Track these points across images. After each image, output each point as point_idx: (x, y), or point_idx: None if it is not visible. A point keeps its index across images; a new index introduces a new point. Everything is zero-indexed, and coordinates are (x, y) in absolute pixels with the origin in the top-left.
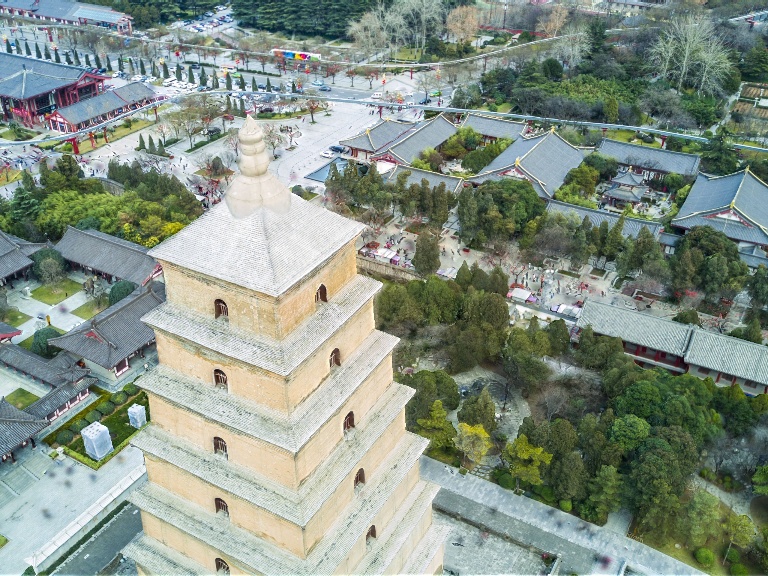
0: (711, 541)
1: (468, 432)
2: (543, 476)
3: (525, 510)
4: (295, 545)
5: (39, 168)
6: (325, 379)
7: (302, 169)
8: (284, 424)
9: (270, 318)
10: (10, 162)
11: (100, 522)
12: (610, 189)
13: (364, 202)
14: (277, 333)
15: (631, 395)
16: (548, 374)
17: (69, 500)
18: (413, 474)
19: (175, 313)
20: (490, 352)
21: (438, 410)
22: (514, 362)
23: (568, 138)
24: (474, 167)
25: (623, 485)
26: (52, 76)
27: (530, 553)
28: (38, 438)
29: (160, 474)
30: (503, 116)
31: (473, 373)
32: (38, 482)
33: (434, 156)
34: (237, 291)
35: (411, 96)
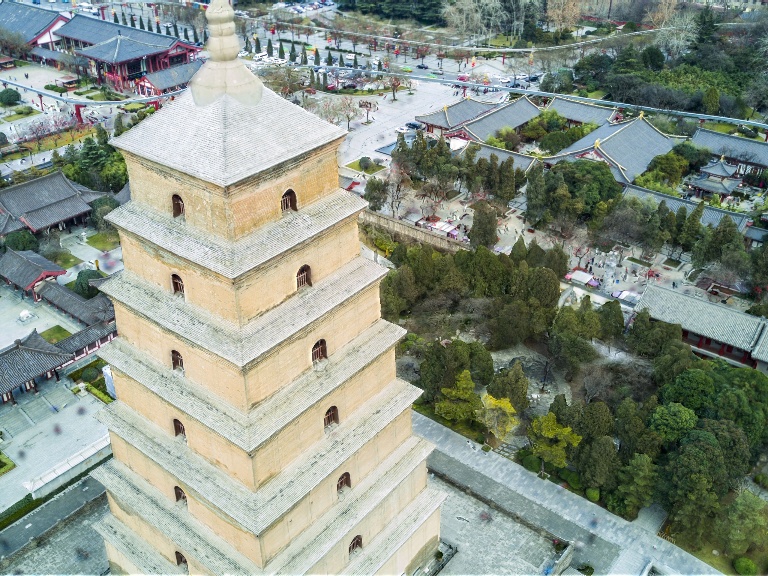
0: (756, 552)
1: (492, 404)
2: (570, 460)
3: (547, 495)
4: (245, 475)
5: (114, 123)
6: (291, 297)
7: (374, 143)
8: (234, 336)
9: (222, 215)
10: (95, 121)
11: (105, 457)
12: (698, 179)
13: (430, 176)
14: (229, 232)
15: (681, 383)
16: (594, 357)
17: (82, 434)
18: (403, 426)
19: (137, 211)
20: (534, 330)
21: (466, 381)
22: (558, 341)
23: (659, 126)
24: (552, 149)
25: (657, 477)
26: (145, 43)
27: (541, 537)
28: (65, 373)
29: (126, 391)
30: (593, 103)
31: (515, 351)
32: (56, 414)
33: (511, 136)
34: (191, 184)
35: (498, 79)
